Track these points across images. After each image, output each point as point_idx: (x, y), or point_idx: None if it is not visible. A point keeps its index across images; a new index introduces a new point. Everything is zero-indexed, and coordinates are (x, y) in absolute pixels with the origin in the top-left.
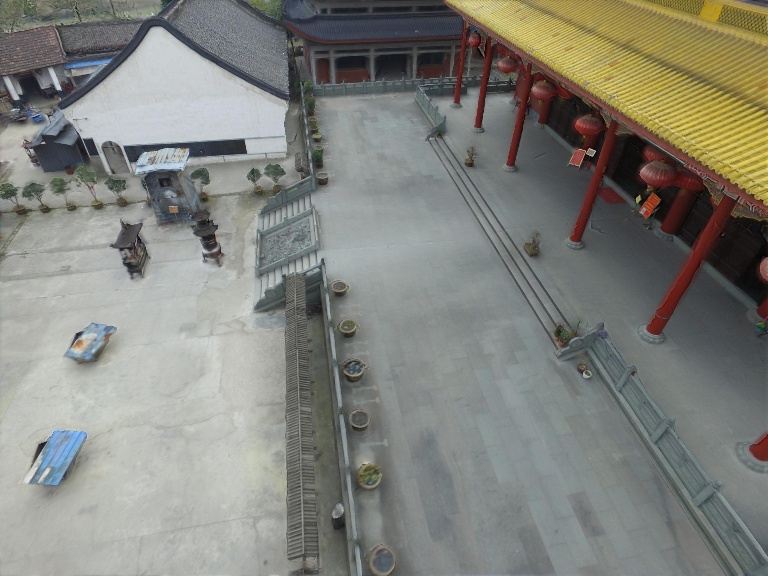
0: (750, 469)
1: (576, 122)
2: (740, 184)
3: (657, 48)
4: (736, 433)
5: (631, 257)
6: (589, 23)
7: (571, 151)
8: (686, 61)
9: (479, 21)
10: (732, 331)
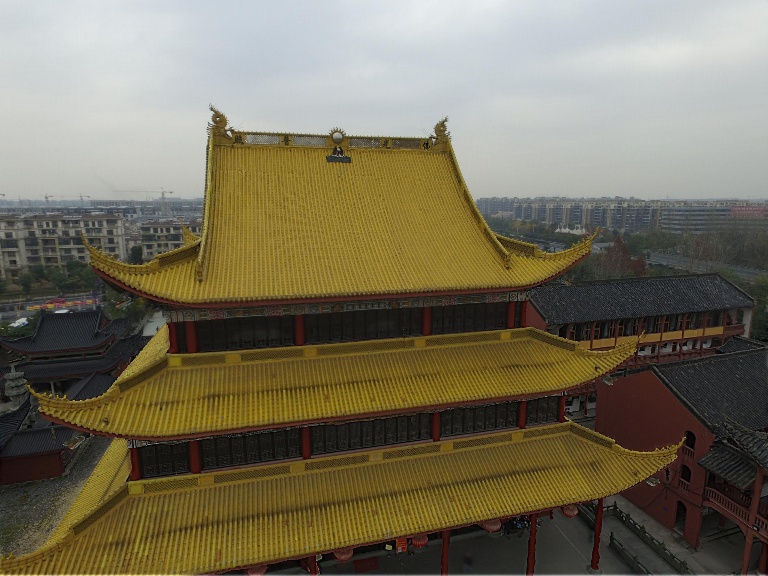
0: (602, 574)
1: (419, 544)
2: (585, 500)
3: (450, 477)
4: (583, 572)
5: (451, 574)
6: (380, 490)
7: (286, 573)
8: (476, 474)
9: (261, 562)
10: (509, 548)
